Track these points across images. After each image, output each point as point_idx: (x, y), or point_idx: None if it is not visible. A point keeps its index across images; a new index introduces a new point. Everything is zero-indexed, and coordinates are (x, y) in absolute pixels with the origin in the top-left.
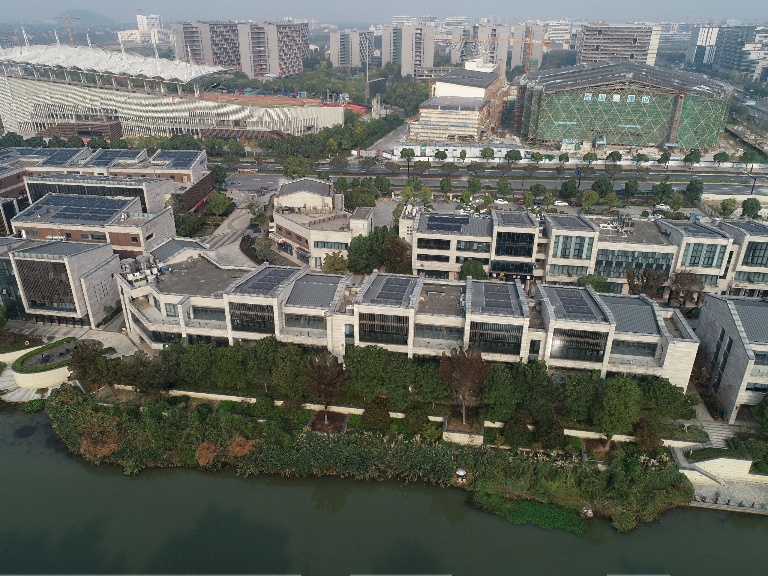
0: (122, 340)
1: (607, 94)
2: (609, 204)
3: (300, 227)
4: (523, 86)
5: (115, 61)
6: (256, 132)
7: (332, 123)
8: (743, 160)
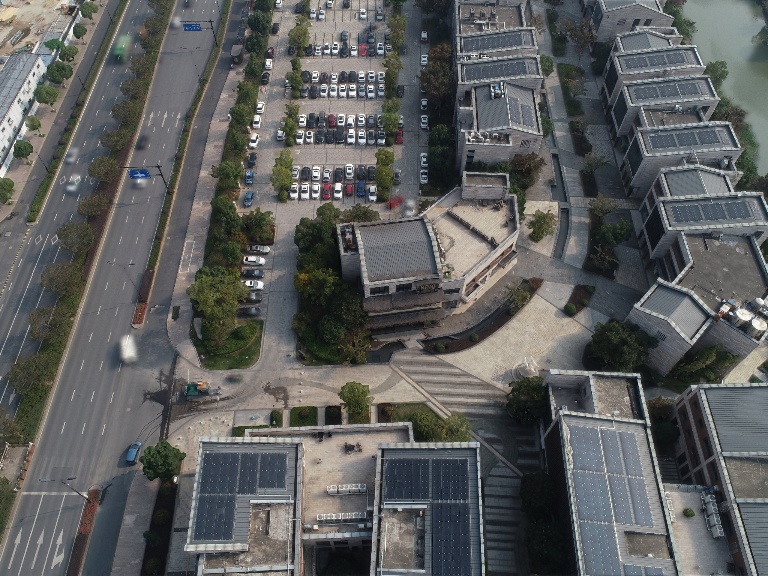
0: (734, 379)
1: None
2: None
3: None
4: None
5: None
6: None
7: None
8: None
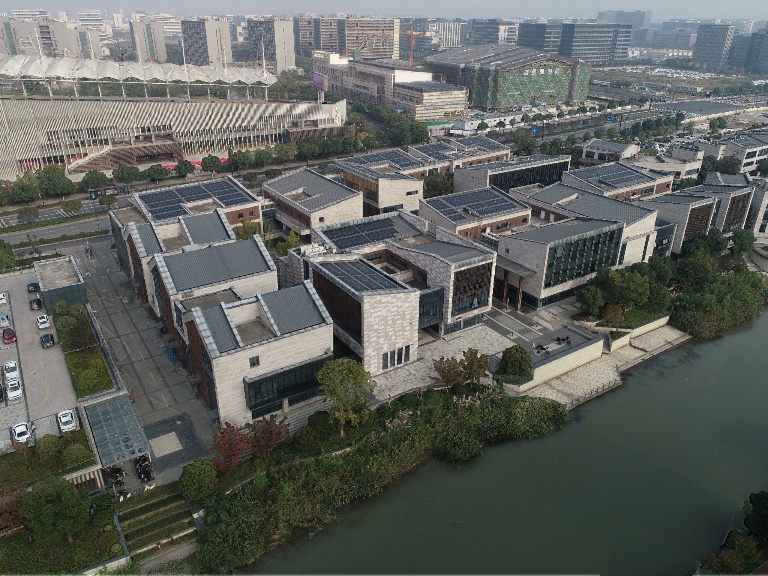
0: (759, 239)
1: (537, 69)
2: (672, 133)
3: (673, 164)
4: (462, 69)
5: (152, 68)
6: (343, 128)
7: (345, 115)
8: (631, 104)
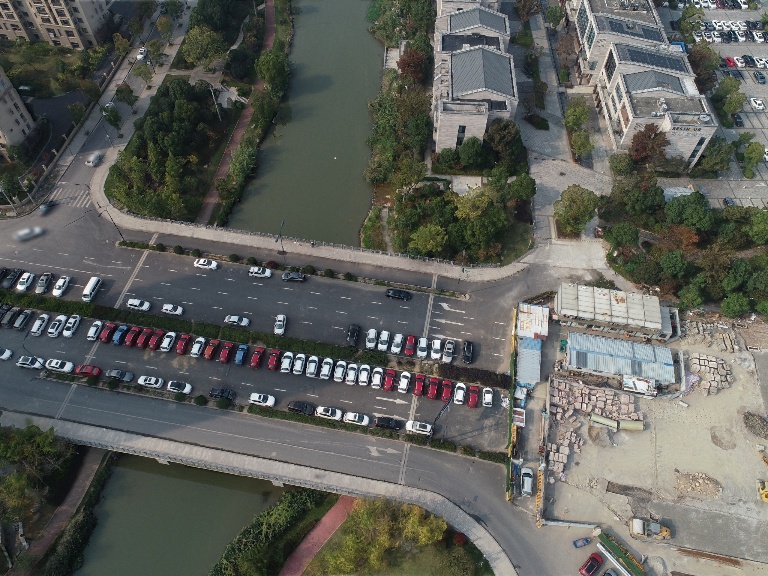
0: None
1: None
2: None
3: None
4: None
5: None
6: None
7: None
8: None
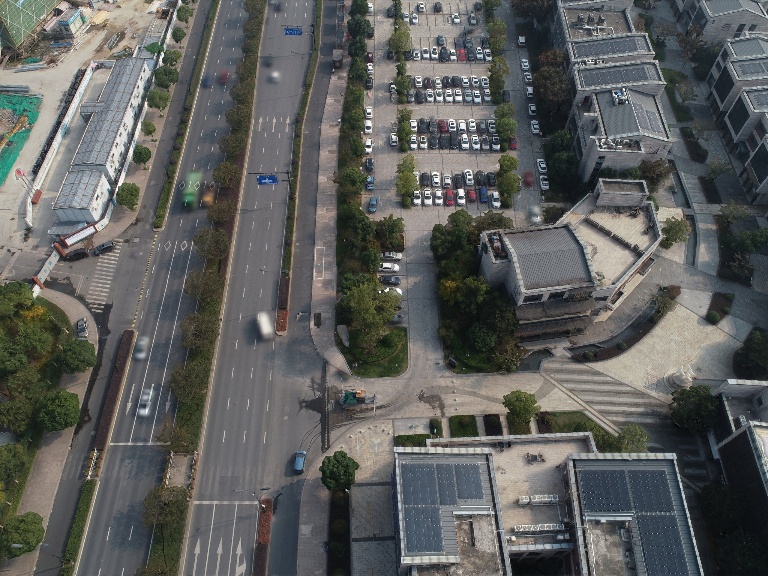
0: None
1: None
2: None
3: None
4: None
5: None
6: None
7: None
8: None
